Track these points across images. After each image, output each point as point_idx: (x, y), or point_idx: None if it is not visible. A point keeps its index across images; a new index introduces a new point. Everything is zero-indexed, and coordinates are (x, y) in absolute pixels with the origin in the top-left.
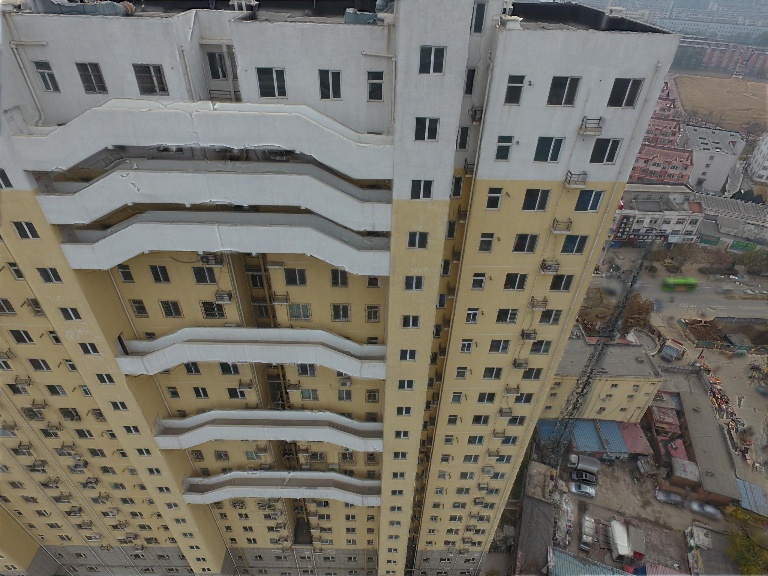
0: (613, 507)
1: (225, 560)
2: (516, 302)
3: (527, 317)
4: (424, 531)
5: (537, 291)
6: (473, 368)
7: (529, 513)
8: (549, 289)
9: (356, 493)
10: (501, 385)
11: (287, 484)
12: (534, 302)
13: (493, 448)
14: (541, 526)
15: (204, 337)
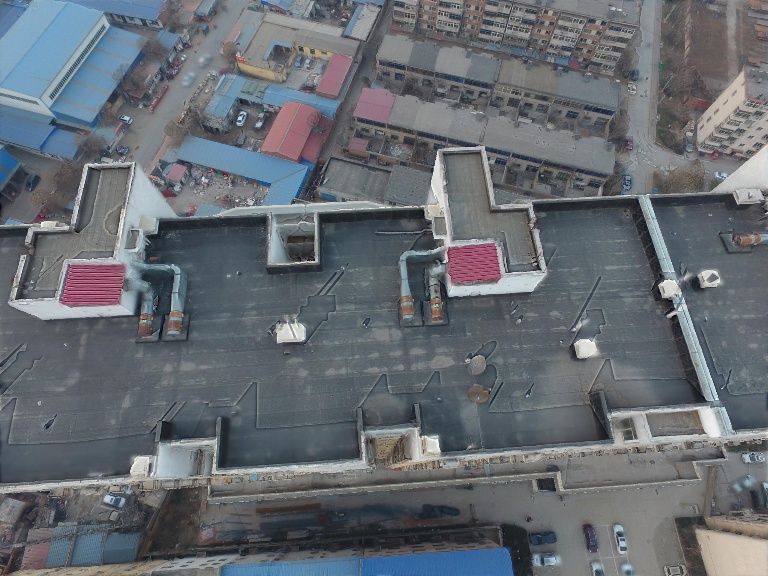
0: None
1: None
2: None
3: None
4: None
5: None
6: None
7: None
8: None
9: None
10: None
11: None
12: None
13: None
14: None
15: None
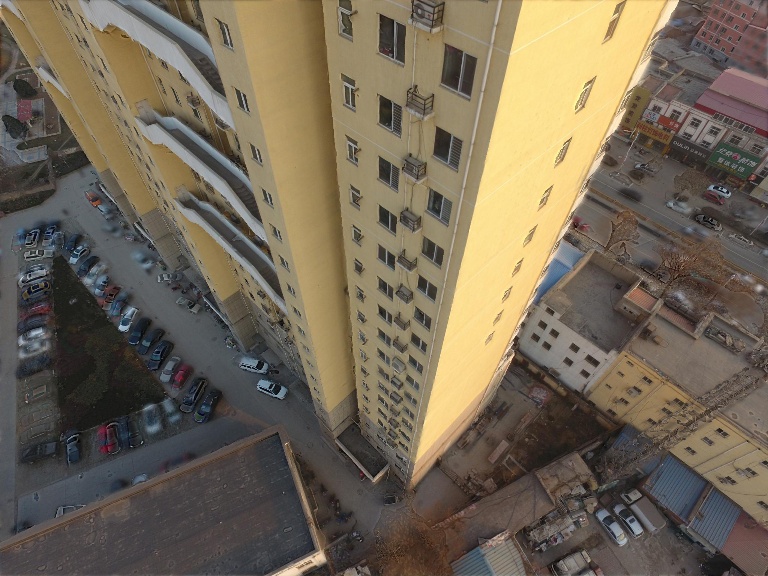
0: (635, 575)
1: (233, 296)
2: (396, 89)
3: (414, 131)
4: (359, 391)
5: (422, 76)
6: (365, 196)
7: (520, 488)
8: (442, 80)
9: (272, 287)
10: (398, 246)
11: (234, 241)
12: (408, 93)
13: (403, 340)
14: (520, 509)
15: (135, 5)
